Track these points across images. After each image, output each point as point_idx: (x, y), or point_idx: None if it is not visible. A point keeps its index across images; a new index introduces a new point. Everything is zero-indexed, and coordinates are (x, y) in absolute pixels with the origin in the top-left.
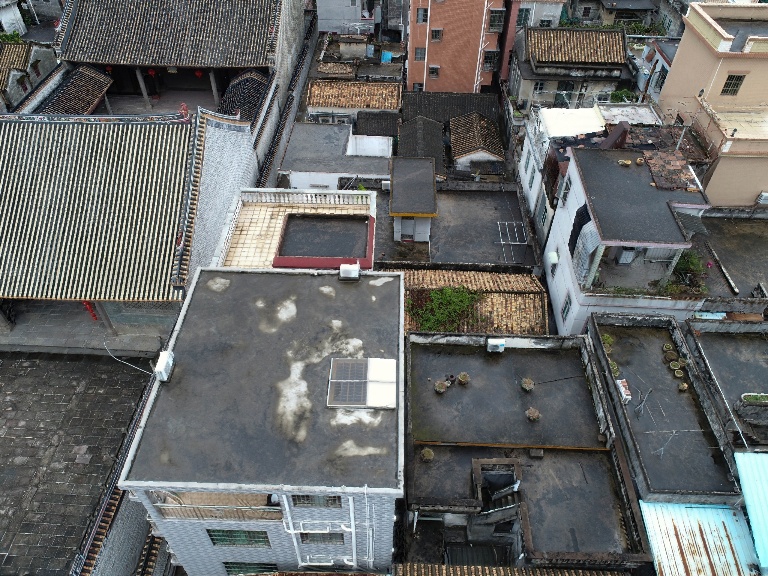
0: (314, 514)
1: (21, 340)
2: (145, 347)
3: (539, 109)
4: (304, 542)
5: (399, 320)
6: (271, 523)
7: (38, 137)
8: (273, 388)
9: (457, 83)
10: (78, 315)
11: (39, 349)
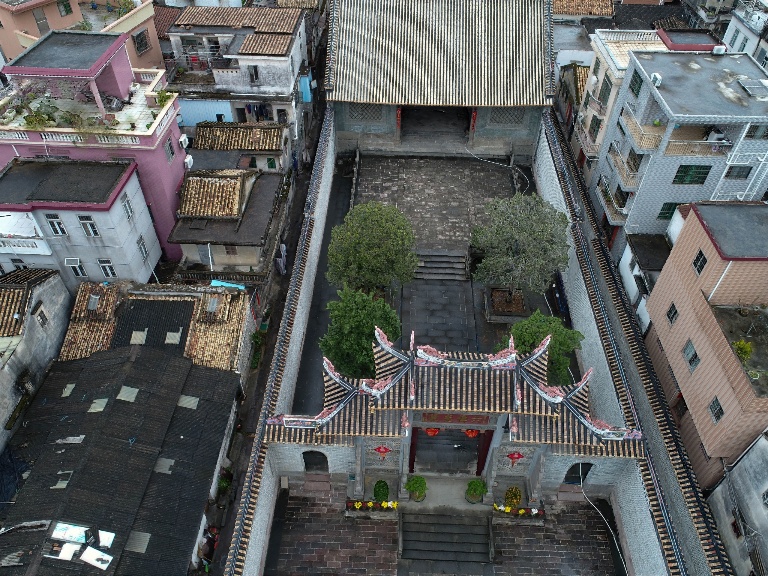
0: (750, 146)
1: (411, 149)
2: (496, 153)
3: (745, 1)
4: (724, 178)
5: (761, 69)
6: (720, 157)
7: (437, 8)
8: (715, 90)
9: (647, 0)
10: (439, 137)
11: (426, 154)
